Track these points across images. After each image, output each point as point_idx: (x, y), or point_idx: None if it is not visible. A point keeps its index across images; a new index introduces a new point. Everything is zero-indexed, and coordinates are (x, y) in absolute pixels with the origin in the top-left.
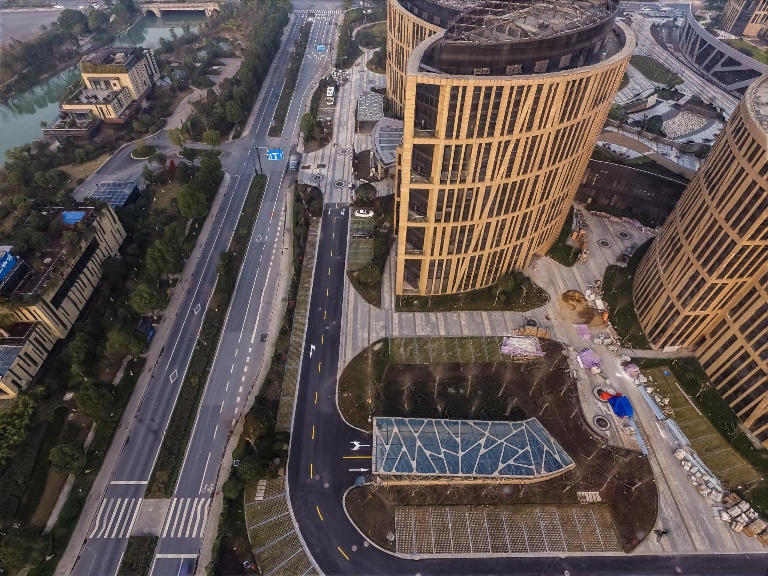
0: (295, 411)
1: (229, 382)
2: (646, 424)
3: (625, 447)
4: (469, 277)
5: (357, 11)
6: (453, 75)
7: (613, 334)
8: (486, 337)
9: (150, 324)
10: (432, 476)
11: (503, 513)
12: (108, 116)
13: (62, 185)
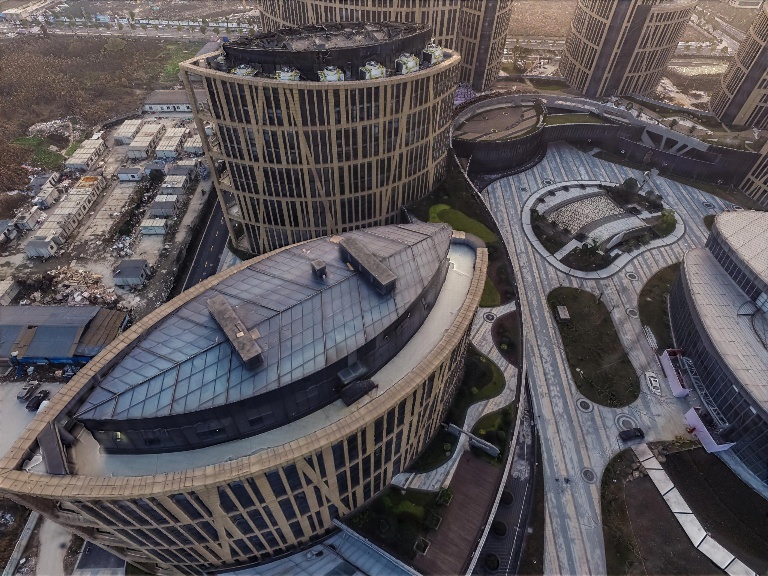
0: None
1: None
2: None
3: None
4: None
5: None
6: None
7: None
8: None
9: None
10: None
11: None
12: None
13: None
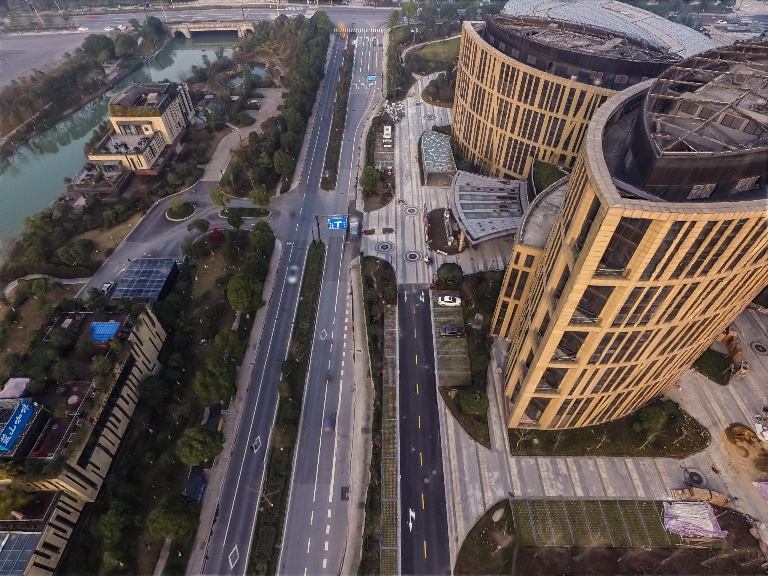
0: None
1: (307, 569)
2: None
3: None
4: (607, 411)
5: (405, 31)
6: (675, 204)
7: None
8: (639, 502)
9: (201, 477)
10: None
11: None
12: (139, 167)
13: (89, 261)
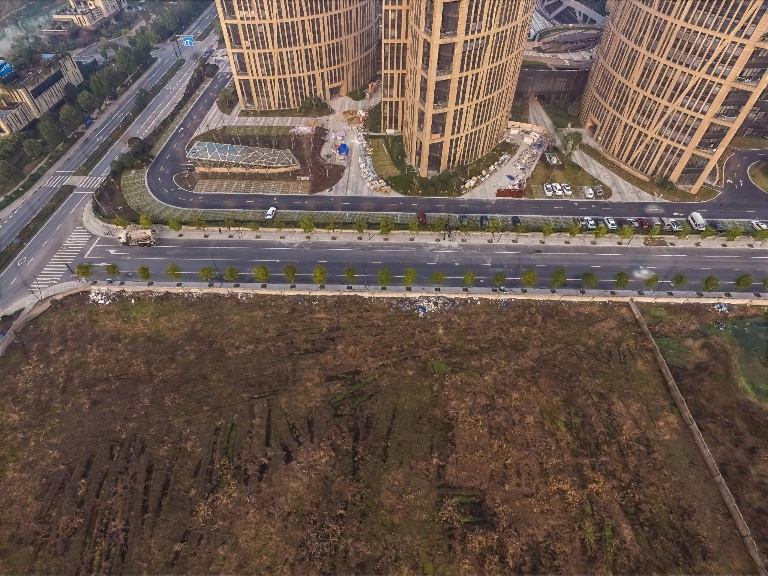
0: (161, 149)
1: None
2: (353, 157)
3: (335, 164)
4: (283, 97)
5: None
6: None
7: (361, 126)
8: (285, 126)
9: (89, 115)
10: (218, 162)
11: (255, 182)
12: (84, 24)
13: None
